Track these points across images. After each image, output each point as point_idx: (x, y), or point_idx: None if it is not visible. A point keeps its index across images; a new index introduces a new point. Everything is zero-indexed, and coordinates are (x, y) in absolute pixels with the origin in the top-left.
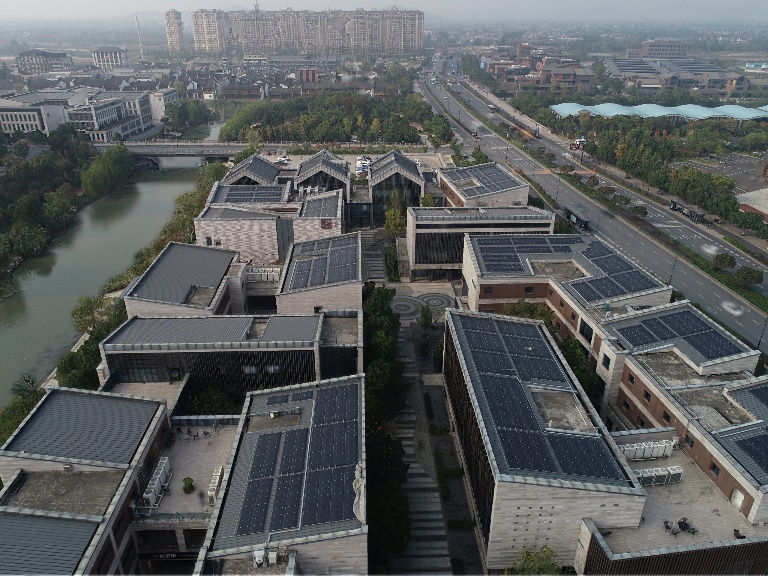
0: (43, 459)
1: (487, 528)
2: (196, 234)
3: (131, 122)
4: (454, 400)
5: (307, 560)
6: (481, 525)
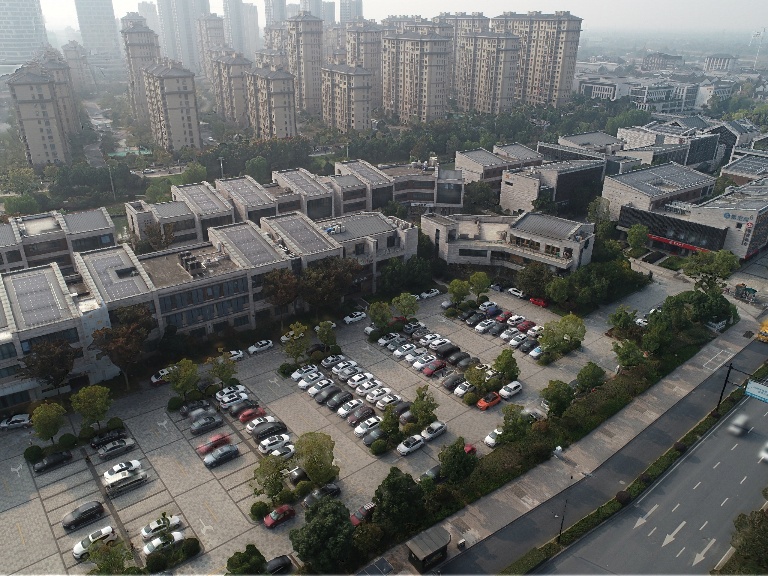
0: (503, 150)
1: None
2: None
3: (673, 103)
4: None
5: (542, 177)
6: None
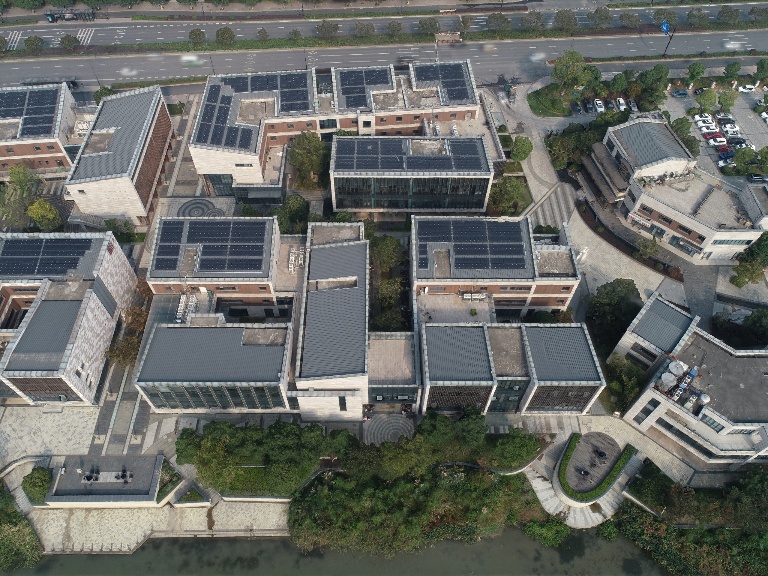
0: None
1: None
2: (71, 383)
3: None
4: (379, 202)
5: None
6: (465, 208)
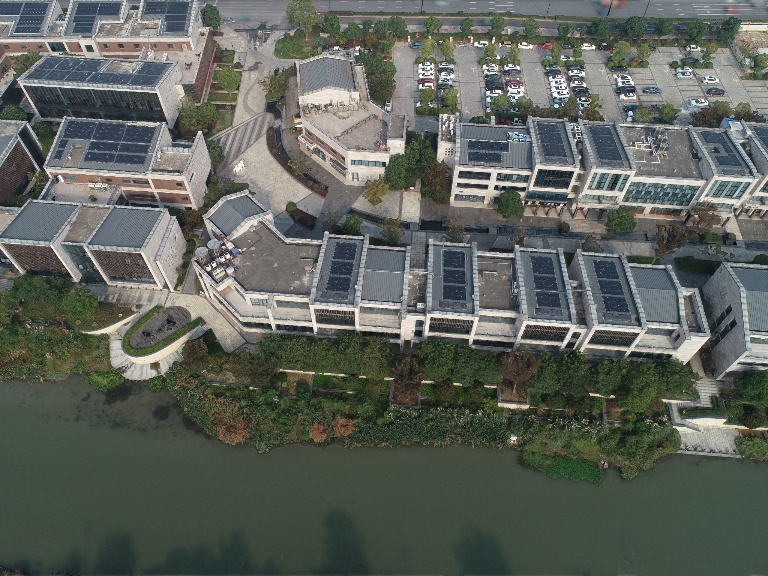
0: None
1: (160, 117)
2: None
3: None
4: (75, 112)
5: None
6: None
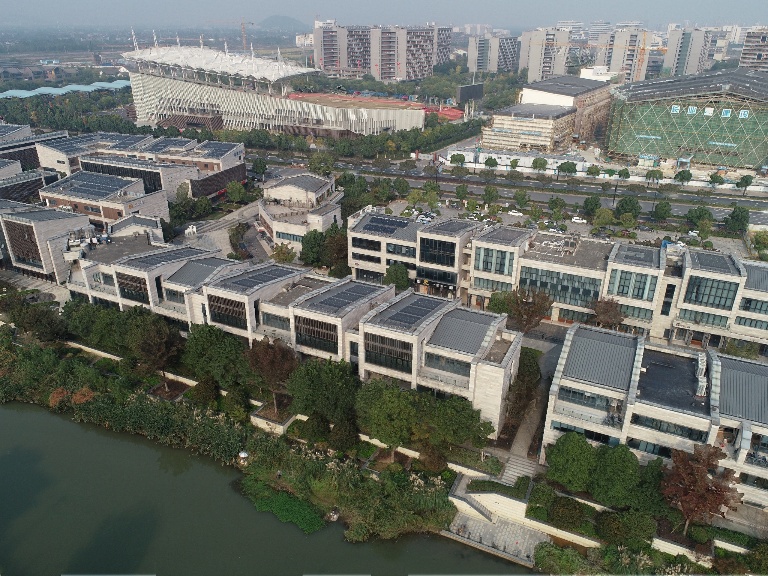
0: (2, 208)
1: None
2: None
3: None
4: None
5: None
6: None
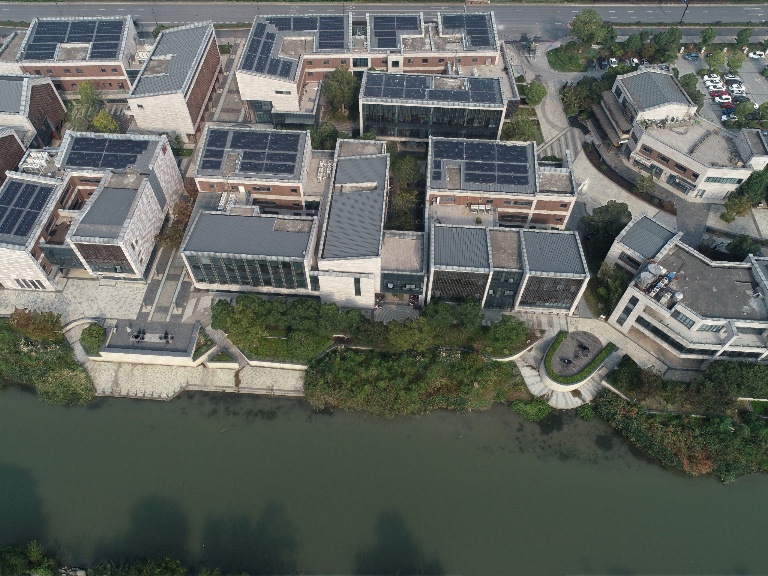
0: None
1: None
2: (127, 251)
3: None
4: (402, 130)
5: None
6: None
